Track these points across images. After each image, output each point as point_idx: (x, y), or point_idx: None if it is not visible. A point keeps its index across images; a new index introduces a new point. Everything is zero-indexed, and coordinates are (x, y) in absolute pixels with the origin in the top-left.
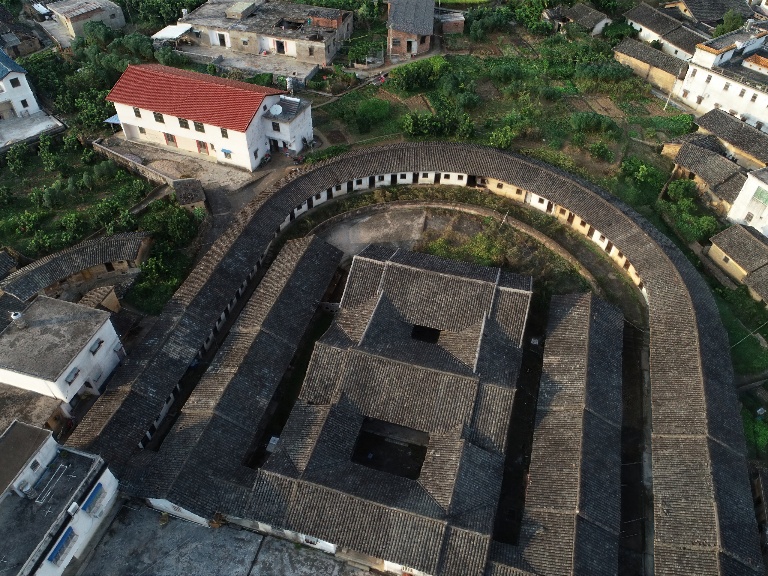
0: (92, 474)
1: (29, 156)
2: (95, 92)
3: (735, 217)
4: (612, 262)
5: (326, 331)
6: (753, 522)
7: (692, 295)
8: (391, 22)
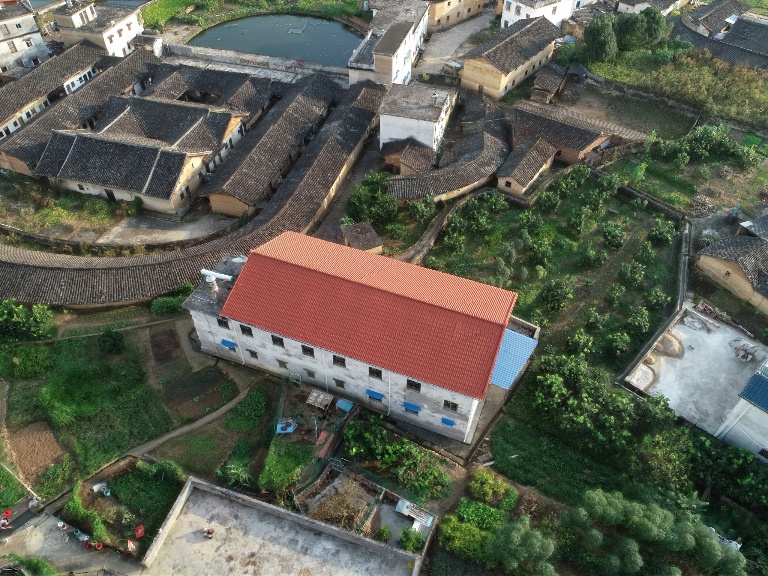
0: (351, 59)
1: (639, 345)
2: (608, 418)
3: None
4: None
5: (225, 132)
6: None
7: None
8: None
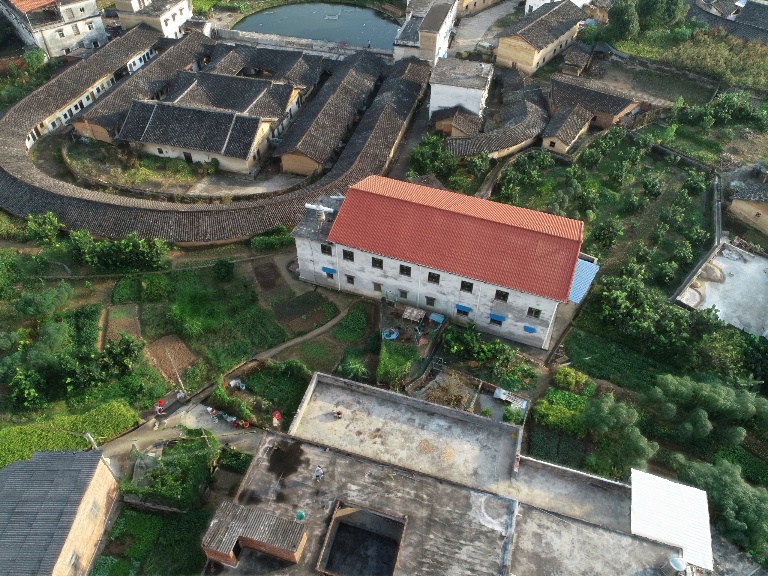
0: None
1: (683, 275)
2: (668, 323)
3: None
4: None
5: (288, 102)
6: None
7: None
8: (88, 434)
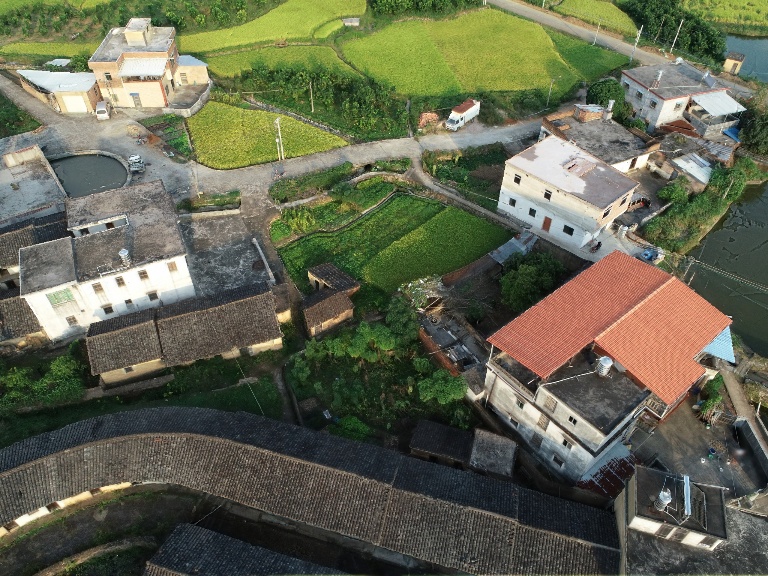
0: None
1: None
2: None
3: (59, 333)
4: (76, 508)
5: None
6: (471, 476)
7: (189, 431)
8: None
